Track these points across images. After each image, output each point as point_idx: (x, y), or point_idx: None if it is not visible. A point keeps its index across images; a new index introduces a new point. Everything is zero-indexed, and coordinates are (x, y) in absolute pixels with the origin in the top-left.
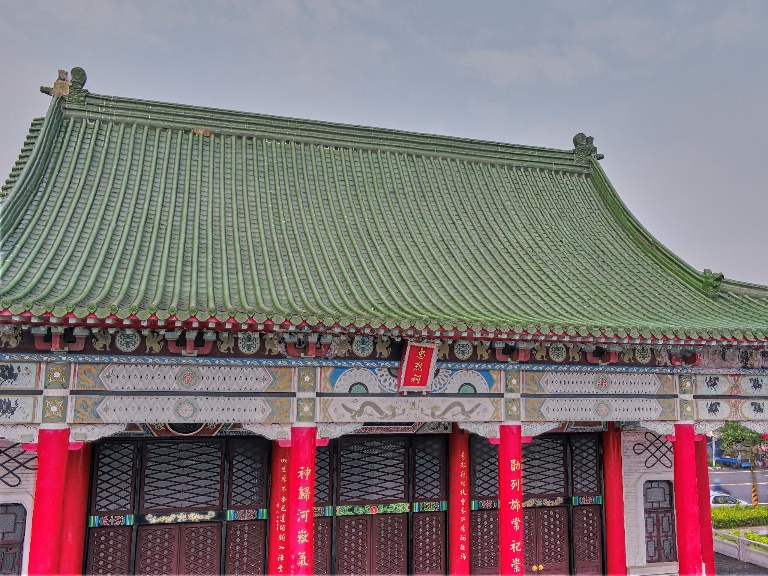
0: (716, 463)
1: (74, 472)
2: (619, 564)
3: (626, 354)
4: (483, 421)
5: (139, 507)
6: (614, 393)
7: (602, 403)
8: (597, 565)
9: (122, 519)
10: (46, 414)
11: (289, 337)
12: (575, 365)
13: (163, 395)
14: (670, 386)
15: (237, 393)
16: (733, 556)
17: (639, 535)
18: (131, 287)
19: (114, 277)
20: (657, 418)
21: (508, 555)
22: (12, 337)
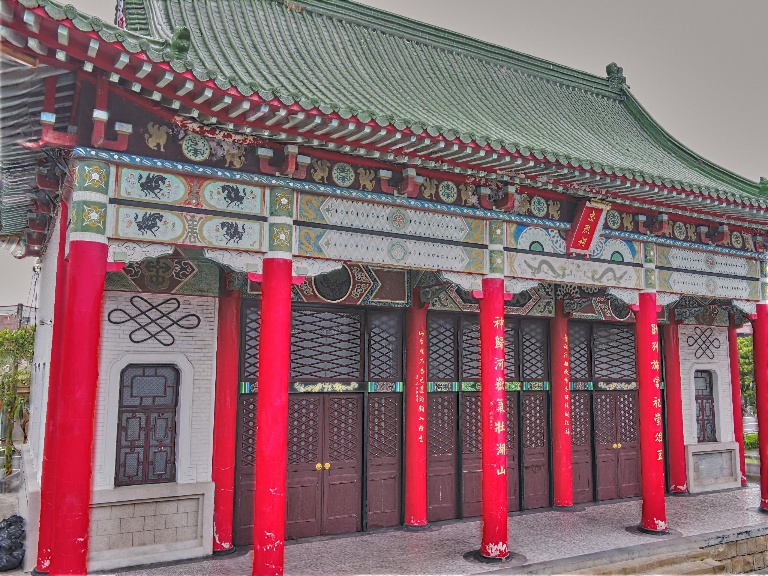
0: None
1: (229, 333)
2: (680, 442)
3: None
4: (628, 288)
5: None
6: (718, 272)
7: (711, 280)
8: None
9: None
10: (275, 242)
11: (484, 189)
12: (695, 243)
13: (377, 235)
14: (754, 270)
15: (440, 240)
16: None
17: (692, 417)
18: None
19: None
20: (747, 297)
21: (651, 410)
22: (236, 157)
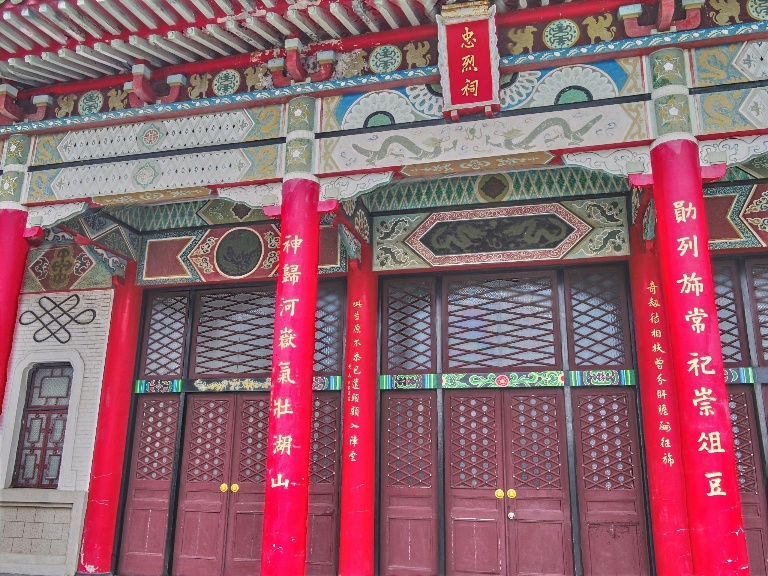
0: None
1: (118, 325)
2: None
3: None
4: (611, 146)
5: (189, 371)
6: None
7: None
8: None
9: (169, 385)
10: None
11: (273, 61)
12: None
13: (121, 160)
14: None
15: (208, 148)
16: None
17: None
18: None
19: None
20: None
21: (684, 383)
22: None
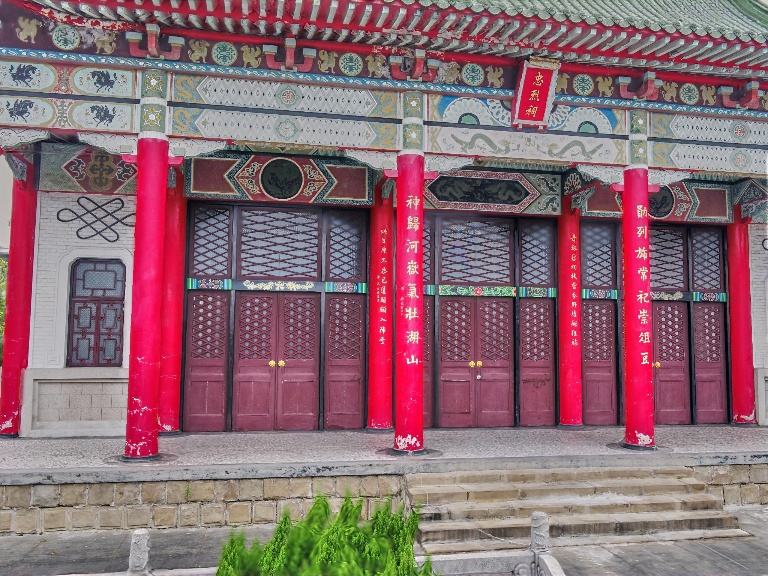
0: None
1: (171, 230)
2: (746, 363)
3: (767, 101)
4: (605, 164)
5: (236, 273)
6: (753, 143)
7: (740, 153)
8: (720, 367)
9: (220, 283)
10: (144, 122)
11: (394, 57)
12: (710, 107)
13: (263, 112)
14: None
15: (340, 116)
16: None
17: (767, 336)
18: None
19: None
20: None
21: (634, 306)
22: (107, 43)
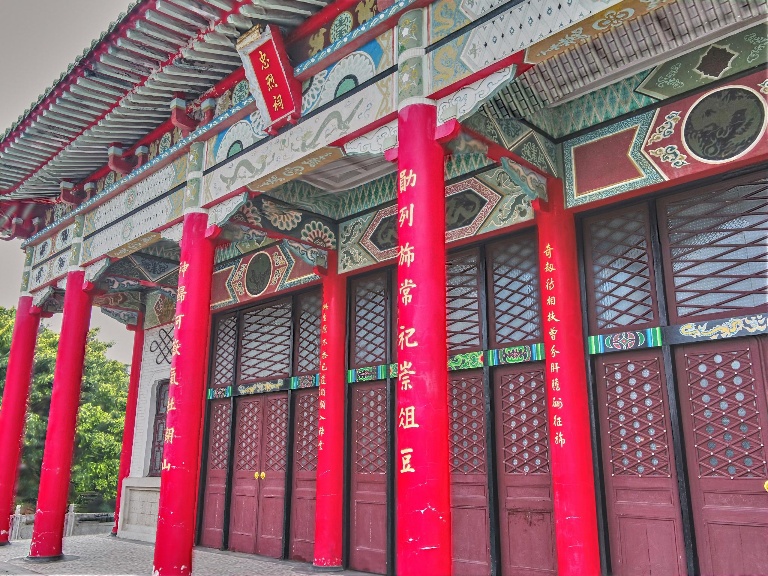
0: None
1: None
2: None
3: None
4: (371, 127)
5: (236, 378)
6: None
7: None
8: None
9: (225, 391)
10: None
11: None
12: None
13: (118, 222)
14: None
15: None
16: None
17: None
18: None
19: None
20: None
21: None
22: (69, 208)
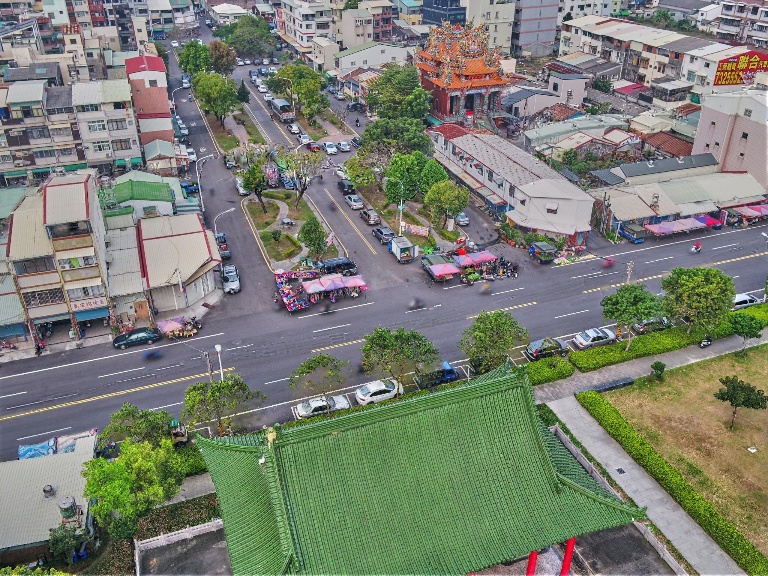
0: (618, 237)
1: None
2: None
3: None
4: None
5: None
6: None
7: None
8: None
9: None
10: None
11: None
12: None
13: None
14: None
15: None
16: (574, 455)
17: None
18: (350, 573)
19: (342, 568)
20: None
21: None
22: None
